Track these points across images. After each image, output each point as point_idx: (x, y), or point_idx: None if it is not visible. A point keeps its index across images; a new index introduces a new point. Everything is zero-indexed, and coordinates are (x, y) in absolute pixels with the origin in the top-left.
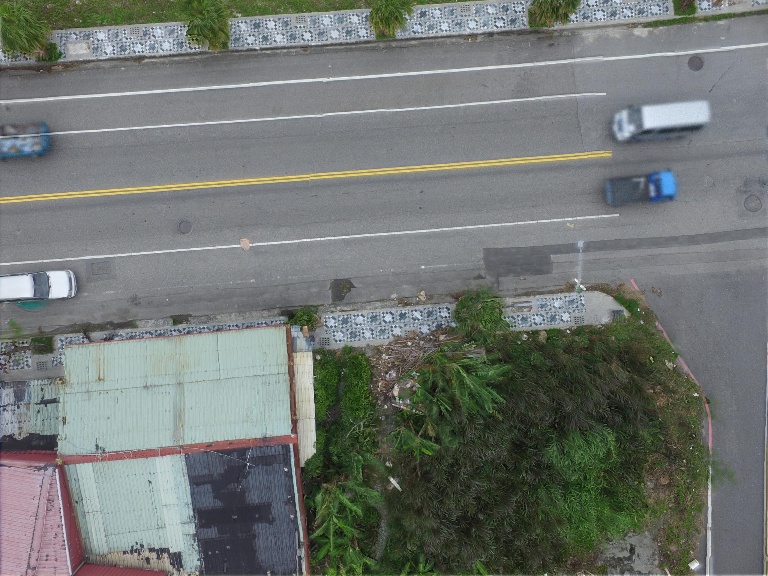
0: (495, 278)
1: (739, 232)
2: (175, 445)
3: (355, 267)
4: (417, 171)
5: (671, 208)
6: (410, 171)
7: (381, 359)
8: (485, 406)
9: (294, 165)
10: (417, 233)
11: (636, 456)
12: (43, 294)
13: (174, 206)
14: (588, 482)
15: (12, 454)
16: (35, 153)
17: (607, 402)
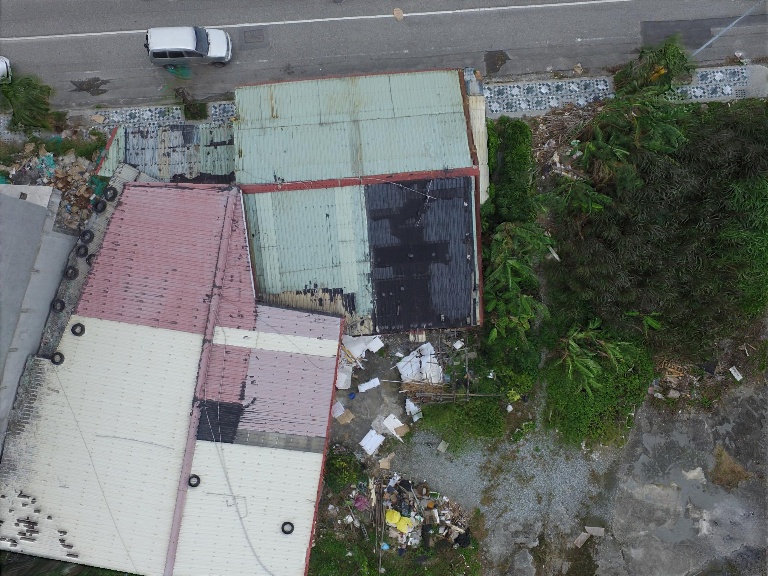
0: None
1: None
2: (354, 176)
3: (510, 38)
4: None
5: None
6: None
7: (538, 129)
8: (671, 140)
9: None
10: (573, 5)
11: None
12: (203, 50)
13: None
14: None
15: None
16: None
17: None
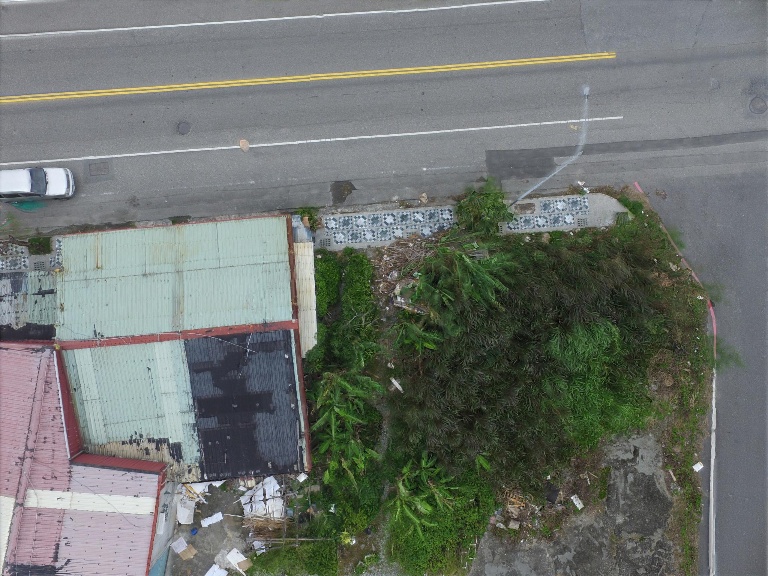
0: (498, 181)
1: (744, 134)
2: (174, 331)
3: (356, 169)
4: (419, 73)
5: (675, 110)
6: (411, 73)
7: (382, 260)
8: (488, 292)
9: (294, 66)
10: (419, 135)
11: (640, 350)
12: (40, 190)
13: (173, 107)
14: (592, 372)
15: (9, 342)
16: (31, 52)
17: (611, 293)
